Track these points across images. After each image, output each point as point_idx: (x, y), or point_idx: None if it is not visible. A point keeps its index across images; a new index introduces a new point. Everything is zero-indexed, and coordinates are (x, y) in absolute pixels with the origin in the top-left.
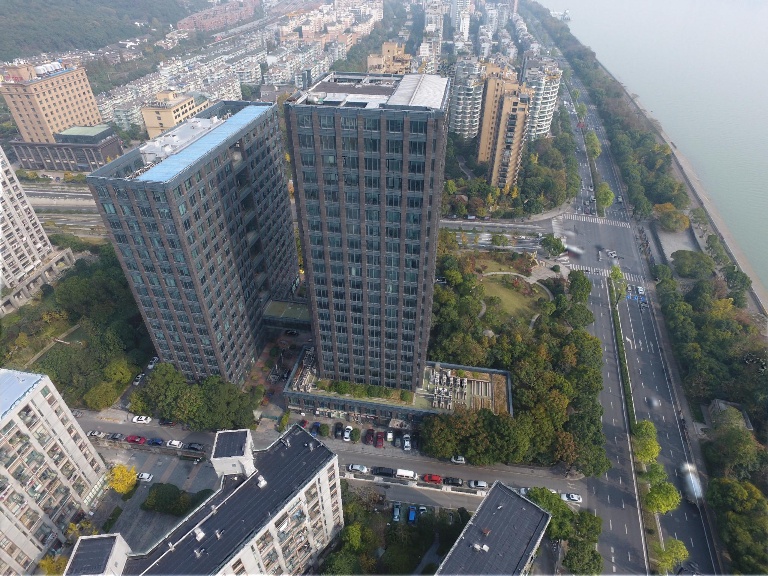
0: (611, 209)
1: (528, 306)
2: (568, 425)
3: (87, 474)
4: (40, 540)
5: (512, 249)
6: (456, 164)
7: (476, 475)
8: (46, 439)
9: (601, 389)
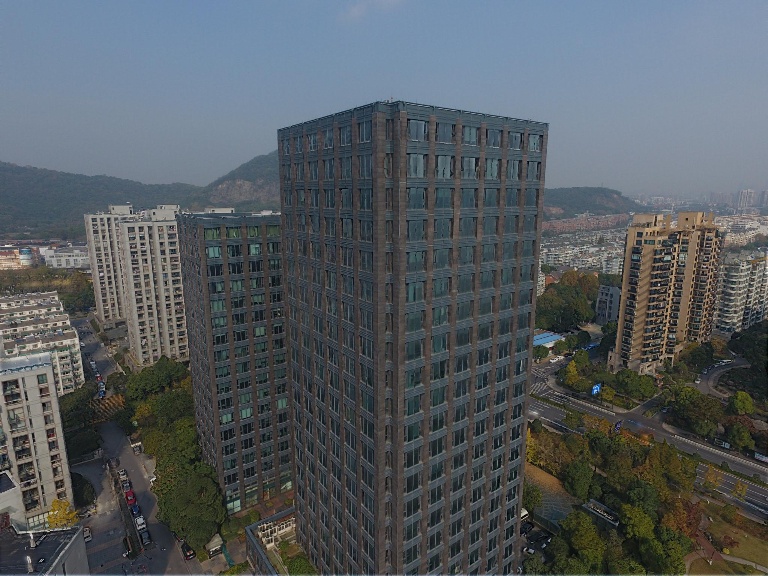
0: None
1: None
2: None
3: (47, 492)
4: None
5: None
6: None
7: None
8: (21, 425)
9: None
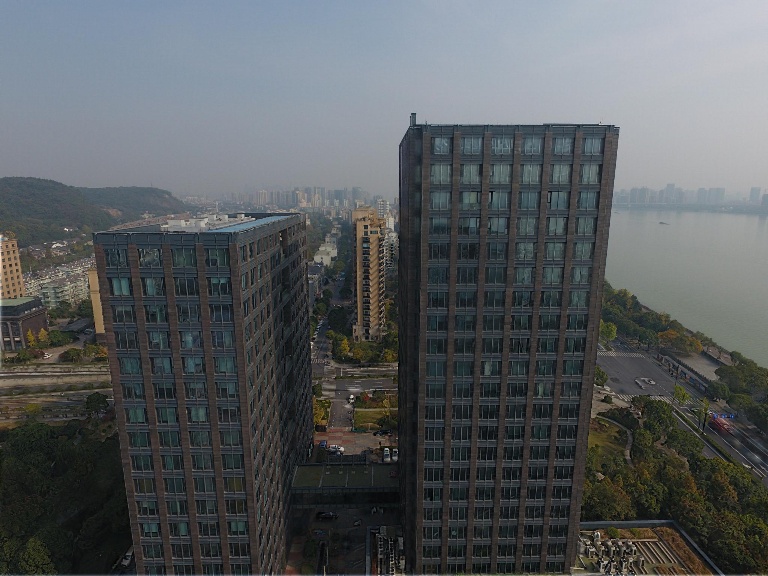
0: (613, 343)
1: (610, 442)
2: None
3: None
4: None
5: None
6: None
7: None
8: None
9: None
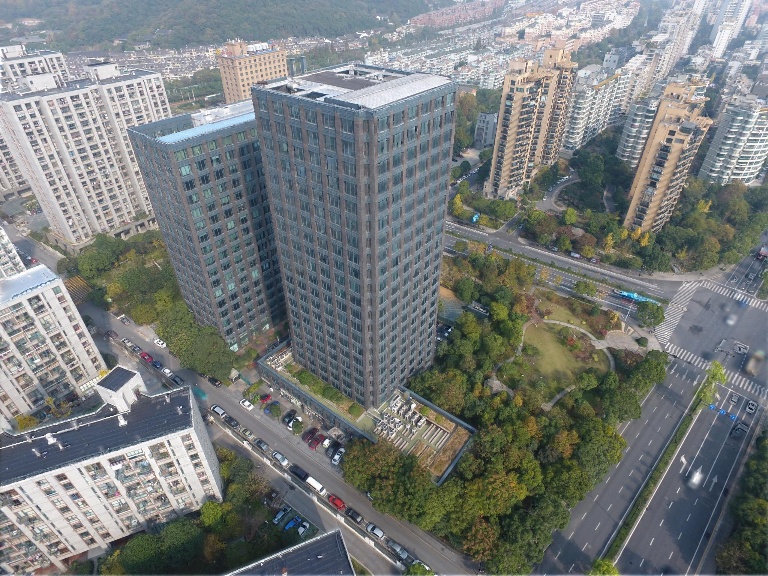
0: None
1: (572, 372)
2: (505, 519)
3: (87, 367)
4: (32, 401)
5: (602, 303)
6: (598, 193)
7: (382, 521)
8: (52, 327)
9: (580, 499)
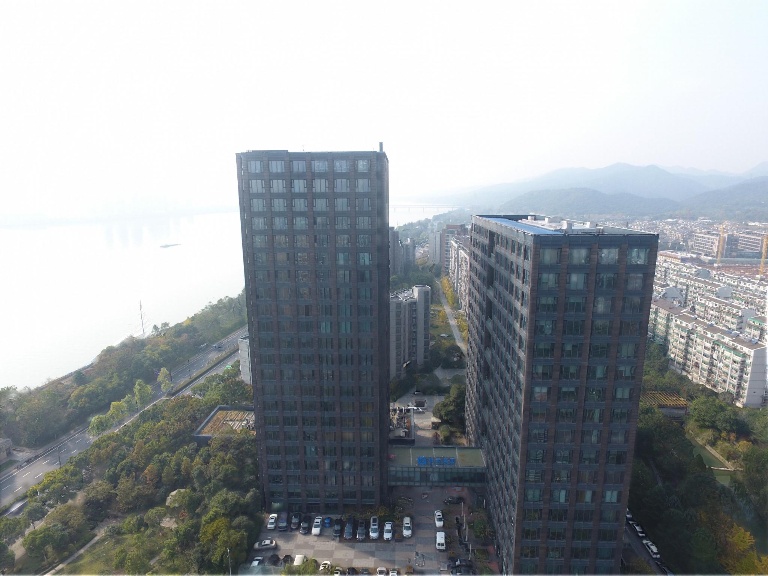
0: None
1: None
2: None
3: None
4: None
5: None
6: None
7: None
8: None
9: None
